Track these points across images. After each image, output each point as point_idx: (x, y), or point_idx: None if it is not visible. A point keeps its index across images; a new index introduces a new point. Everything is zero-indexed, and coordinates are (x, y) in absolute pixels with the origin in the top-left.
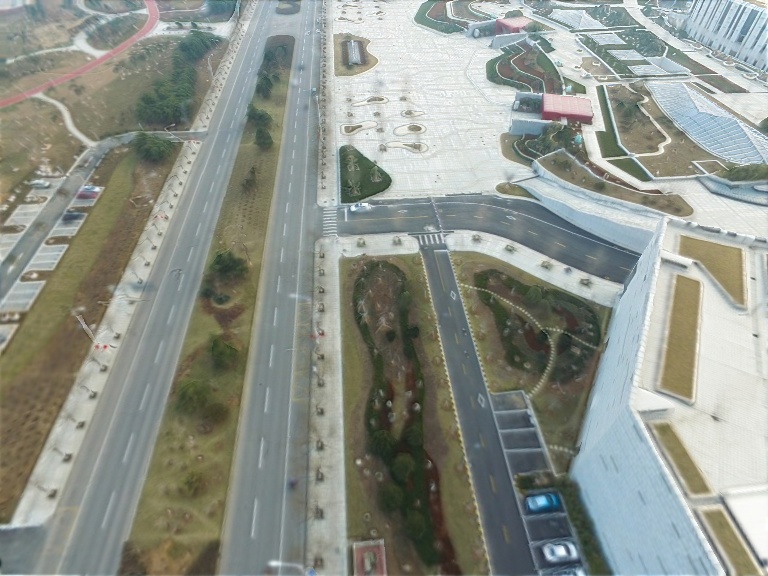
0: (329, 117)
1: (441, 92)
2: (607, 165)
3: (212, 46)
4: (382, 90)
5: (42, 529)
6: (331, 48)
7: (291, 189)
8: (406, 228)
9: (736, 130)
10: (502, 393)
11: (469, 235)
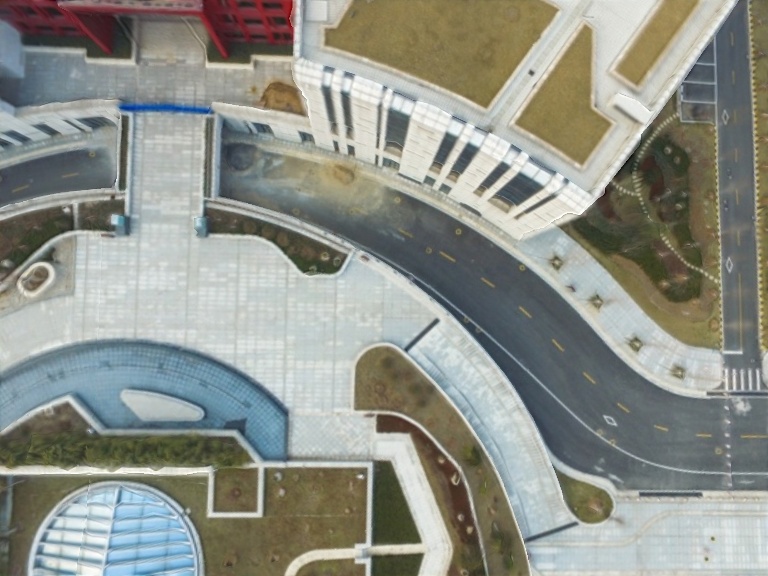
0: None
1: None
2: (428, 525)
3: None
4: None
5: None
6: None
7: None
8: None
9: None
10: (703, 122)
11: (688, 381)
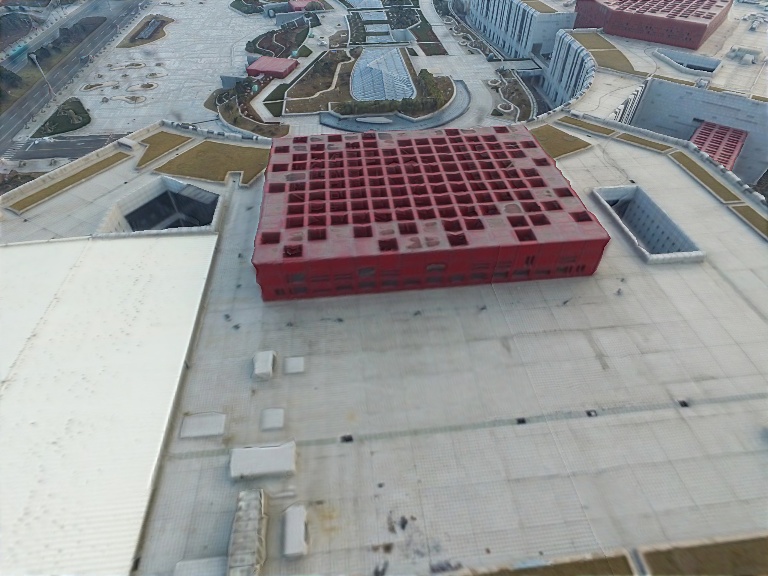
0: (80, 78)
1: (197, 59)
2: (260, 106)
3: (22, 25)
4: (147, 58)
5: None
6: (133, 26)
7: None
8: (71, 155)
9: (379, 79)
10: None
11: None
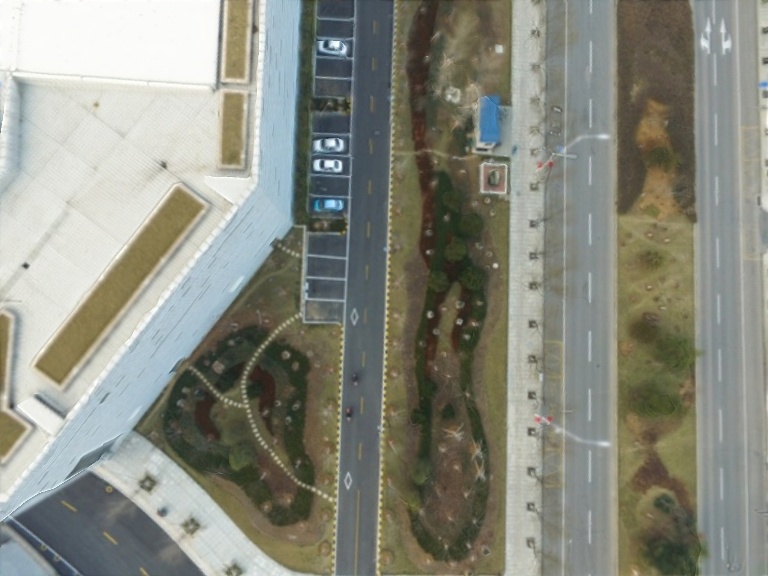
0: None
1: None
2: None
3: None
4: None
5: (766, 244)
6: None
7: None
8: None
9: None
10: (328, 322)
11: None
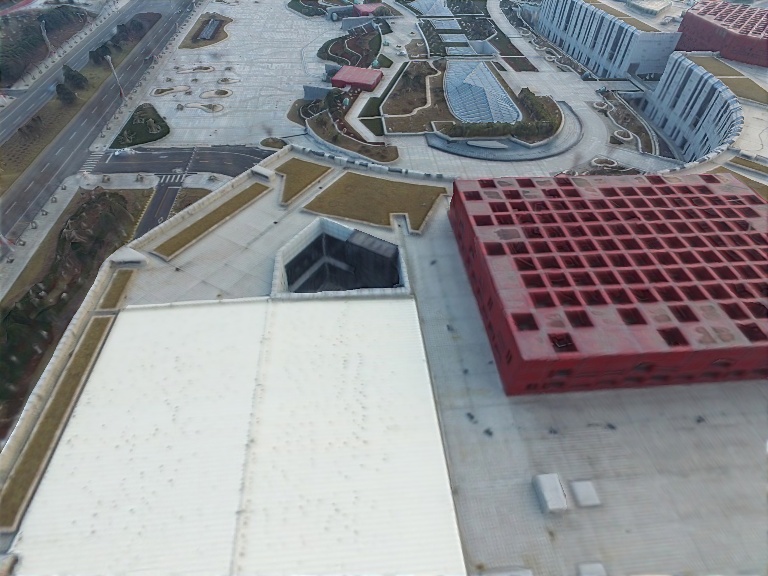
0: (148, 81)
1: (268, 64)
2: (356, 123)
3: (75, 19)
4: (214, 61)
5: None
6: (191, 25)
7: (73, 137)
8: (156, 170)
9: (482, 97)
10: None
11: (208, 176)
